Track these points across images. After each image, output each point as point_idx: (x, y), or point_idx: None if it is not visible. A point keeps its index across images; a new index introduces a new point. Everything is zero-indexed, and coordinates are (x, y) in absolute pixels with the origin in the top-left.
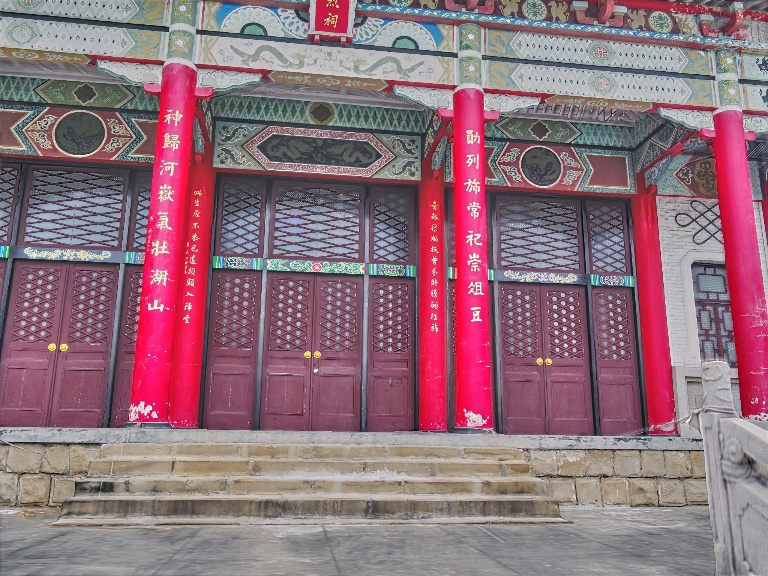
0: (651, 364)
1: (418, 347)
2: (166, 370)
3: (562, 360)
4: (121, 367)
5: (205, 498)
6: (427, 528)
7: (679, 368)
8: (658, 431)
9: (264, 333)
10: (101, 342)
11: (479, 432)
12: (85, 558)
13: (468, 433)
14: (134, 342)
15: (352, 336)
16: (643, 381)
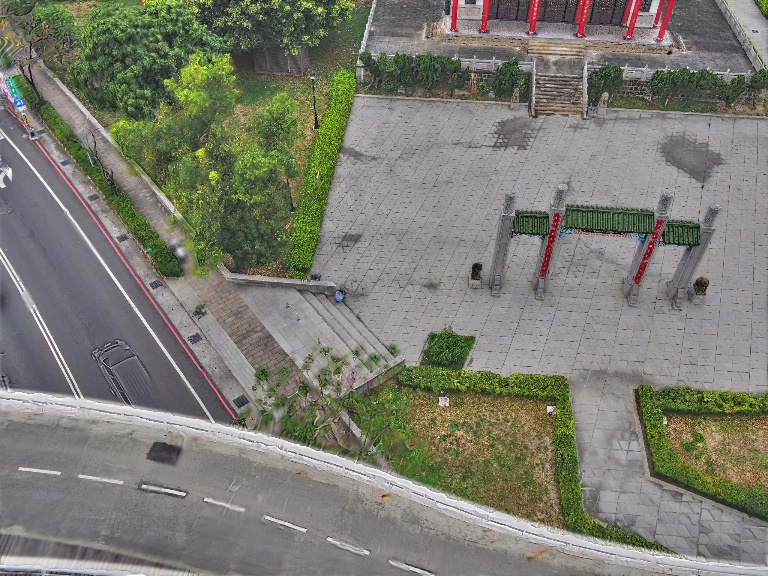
0: (626, 11)
1: (577, 6)
2: None
3: (607, 8)
4: (520, 8)
5: (543, 52)
6: (567, 59)
7: (631, 13)
8: (622, 25)
9: (547, 2)
10: (516, 3)
11: None
12: None
13: (578, 37)
14: (522, 3)
15: (564, 3)
16: (624, 14)
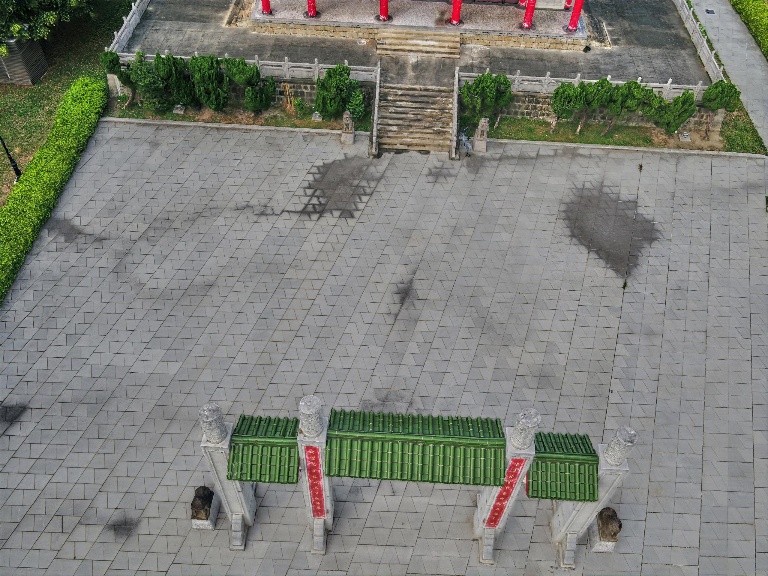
0: None
1: None
2: (387, 8)
3: None
4: None
5: (399, 48)
6: None
7: None
8: (520, 4)
9: None
10: None
11: (455, 25)
12: (389, 71)
13: (452, 25)
14: None
15: None
16: None
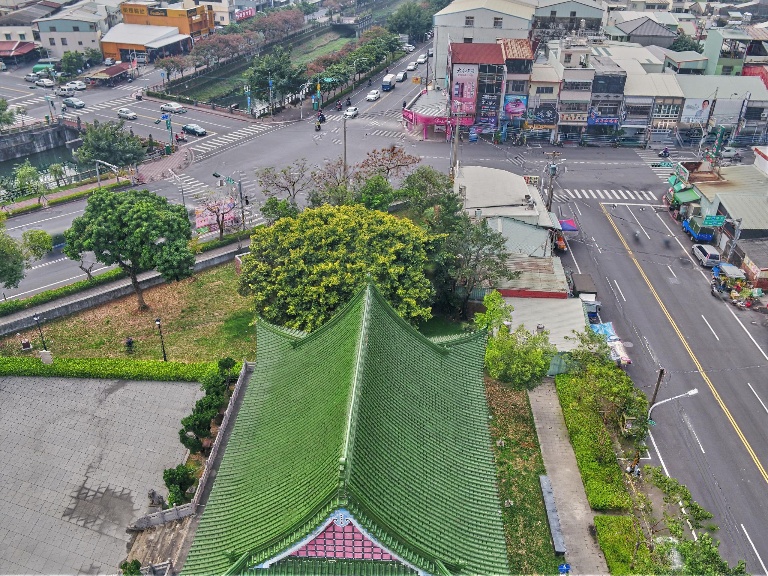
0: None
1: None
2: None
3: None
4: None
5: None
6: None
7: None
8: None
9: None
10: None
11: None
12: None
13: None
14: None
15: None
16: None
